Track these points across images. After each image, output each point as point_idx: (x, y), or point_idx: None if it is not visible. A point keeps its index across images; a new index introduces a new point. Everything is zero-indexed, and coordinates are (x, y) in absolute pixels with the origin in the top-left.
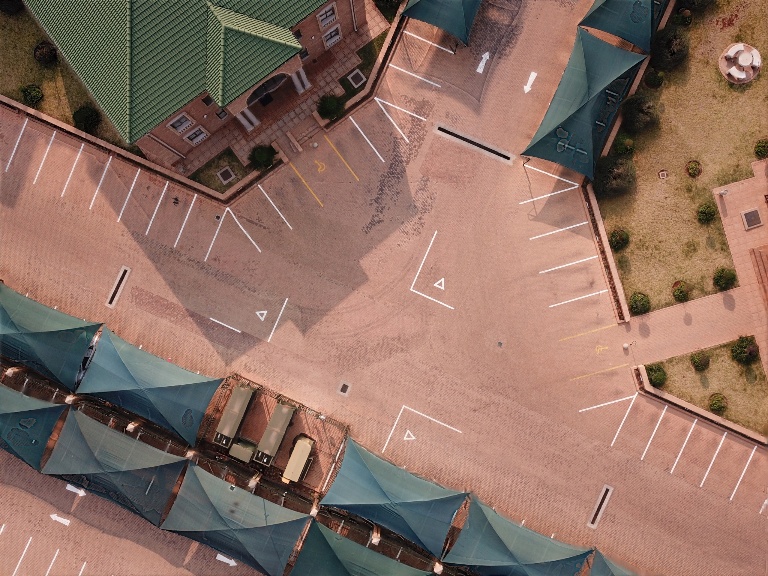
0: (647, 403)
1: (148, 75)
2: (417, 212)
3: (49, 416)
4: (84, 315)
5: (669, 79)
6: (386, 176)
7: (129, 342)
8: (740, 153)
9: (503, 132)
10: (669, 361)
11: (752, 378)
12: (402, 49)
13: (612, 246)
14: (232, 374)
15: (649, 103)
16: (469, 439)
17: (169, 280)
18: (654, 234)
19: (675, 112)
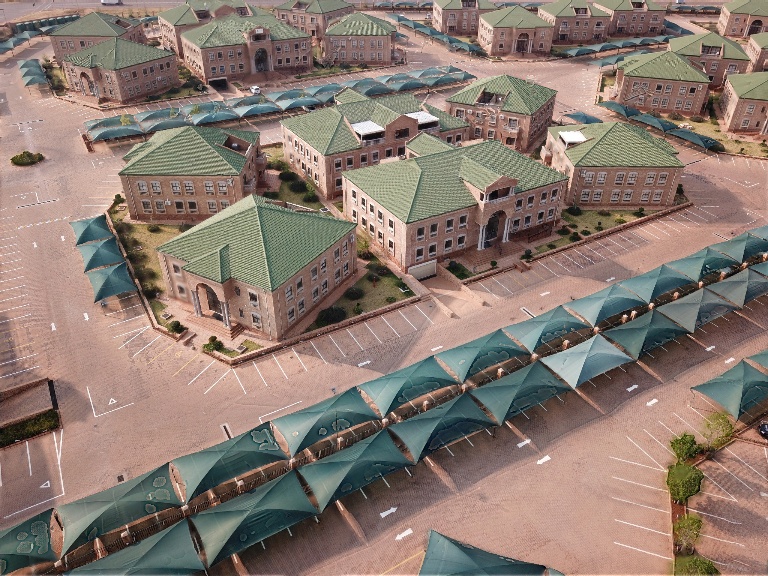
0: None
1: None
2: None
3: None
4: None
5: None
6: None
7: None
8: None
9: None
10: None
11: None
12: None
13: None
14: None
15: None
16: None
17: None
18: None
19: None
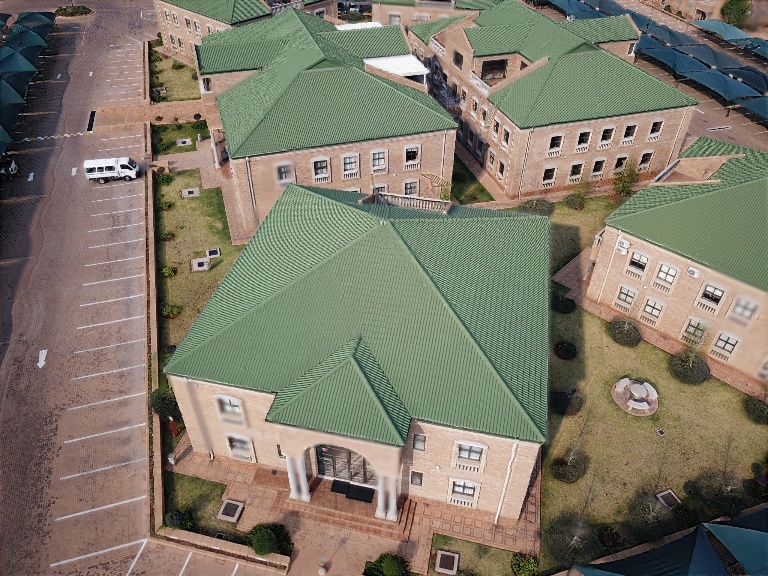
0: None
1: None
2: None
3: None
4: None
5: None
6: None
7: None
8: None
9: None
10: None
11: None
12: None
13: None
14: None
15: None
16: None
17: None
18: None
19: None
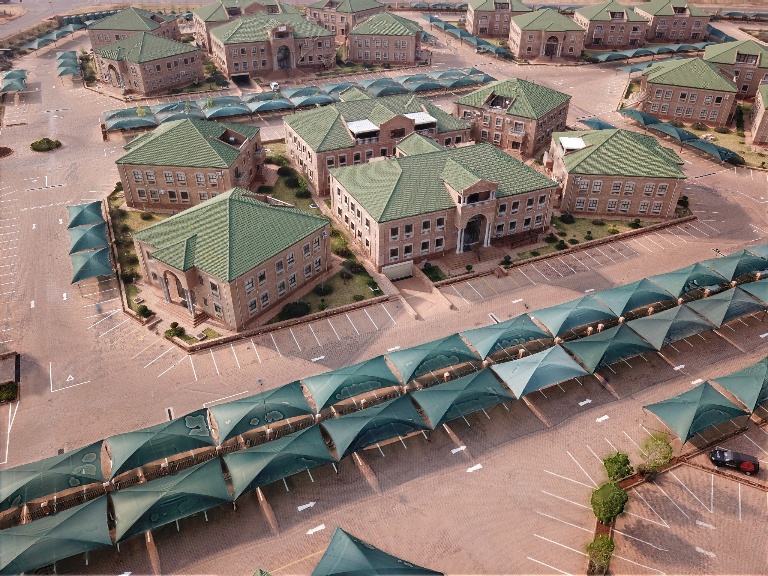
0: None
1: None
2: None
3: None
4: None
5: None
6: None
7: None
8: None
9: None
10: None
11: None
12: None
13: None
14: None
15: None
16: None
17: None
18: None
19: None
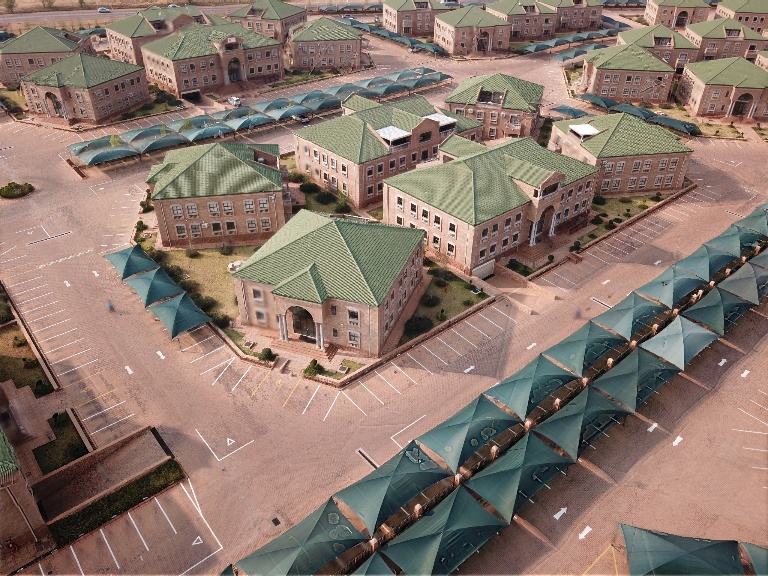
0: None
1: None
2: None
3: None
4: None
5: None
6: None
7: None
8: None
9: None
10: None
11: None
12: None
13: None
14: None
15: None
16: None
17: (731, 204)
18: None
19: None
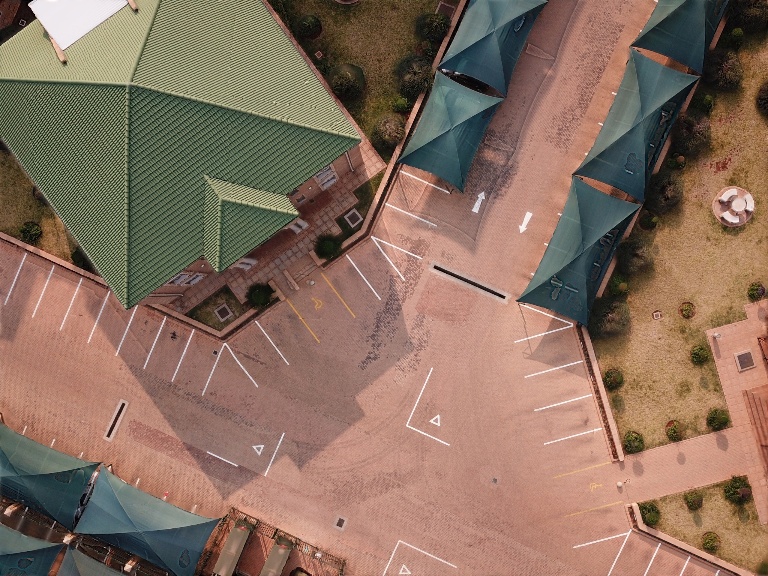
0: (641, 540)
1: (146, 245)
2: (413, 349)
3: (47, 555)
4: (82, 448)
5: (663, 221)
6: (382, 313)
7: (127, 475)
8: (733, 295)
9: (498, 271)
10: (663, 499)
11: (745, 517)
12: (398, 189)
13: (606, 386)
14: (229, 508)
15: (643, 248)
16: (464, 574)
17: (167, 414)
18: (648, 374)
19: (669, 254)
